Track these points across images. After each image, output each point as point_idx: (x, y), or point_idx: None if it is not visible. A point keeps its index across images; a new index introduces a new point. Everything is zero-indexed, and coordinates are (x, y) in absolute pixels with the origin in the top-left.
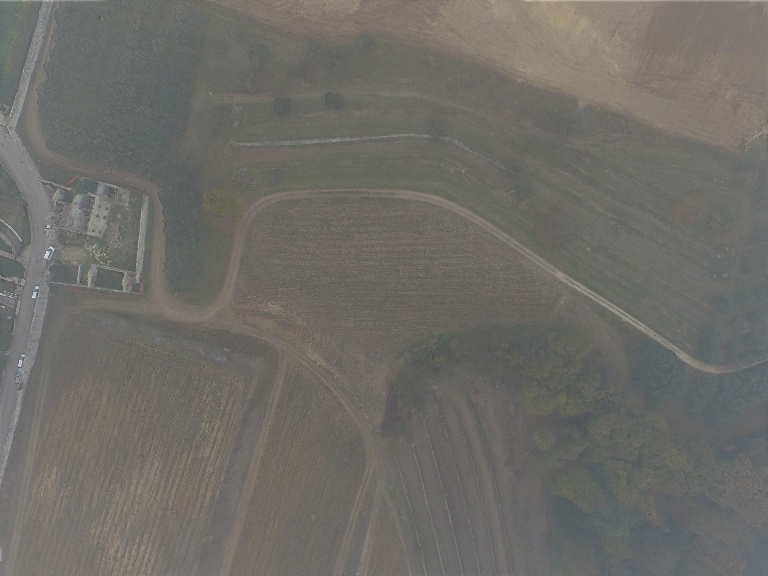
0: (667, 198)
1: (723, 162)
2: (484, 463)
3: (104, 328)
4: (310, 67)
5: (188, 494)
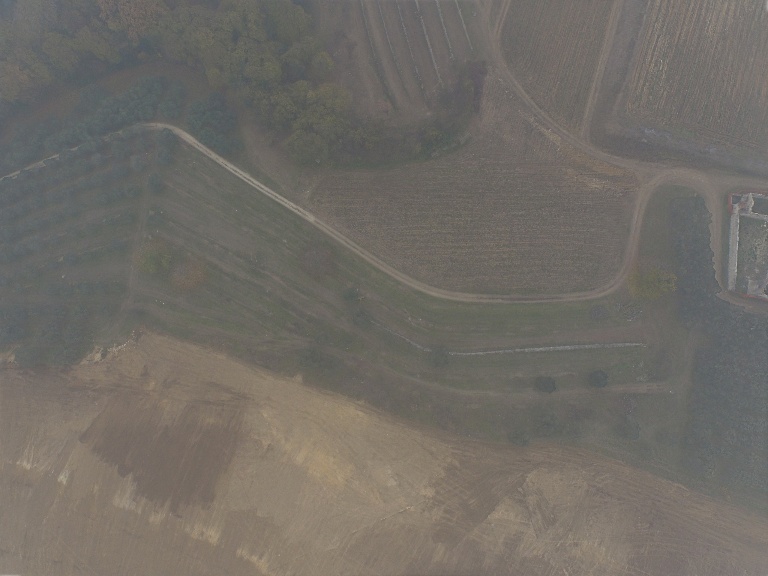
0: (210, 287)
1: (156, 321)
2: (378, 44)
3: (767, 160)
4: (572, 418)
5: (678, 2)
